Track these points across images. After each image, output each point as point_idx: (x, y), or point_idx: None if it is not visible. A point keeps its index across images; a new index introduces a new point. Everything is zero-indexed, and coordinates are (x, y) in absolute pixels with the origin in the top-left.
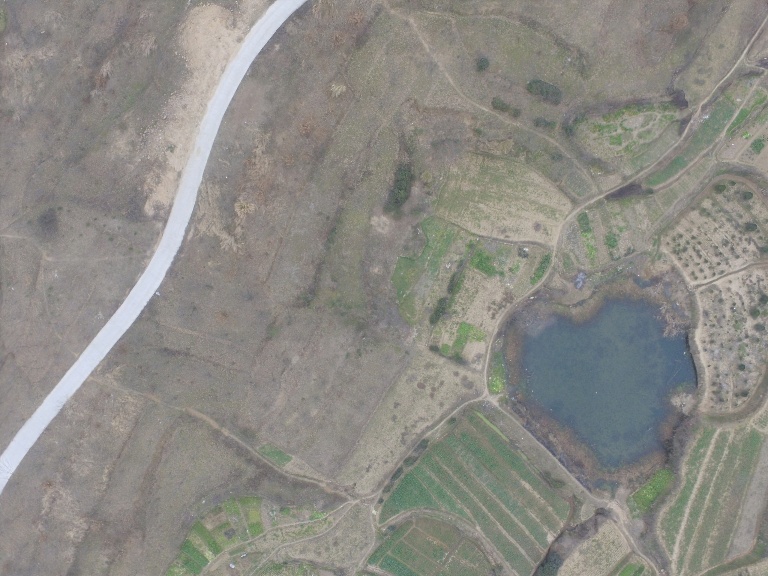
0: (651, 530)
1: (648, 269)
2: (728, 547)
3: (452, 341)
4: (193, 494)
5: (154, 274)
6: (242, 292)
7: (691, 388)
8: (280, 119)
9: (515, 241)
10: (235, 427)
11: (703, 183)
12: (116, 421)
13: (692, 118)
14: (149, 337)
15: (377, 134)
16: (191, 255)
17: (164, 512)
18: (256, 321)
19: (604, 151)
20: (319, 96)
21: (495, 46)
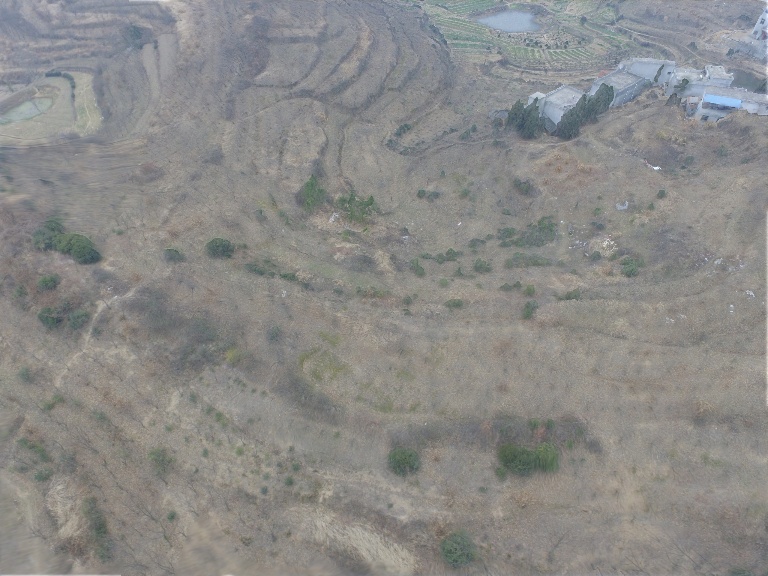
0: None
1: None
2: None
3: None
4: None
5: None
6: None
7: None
8: None
9: None
10: None
11: None
12: None
13: None
14: None
15: None
16: None
17: None
18: None
19: None
20: None
21: None
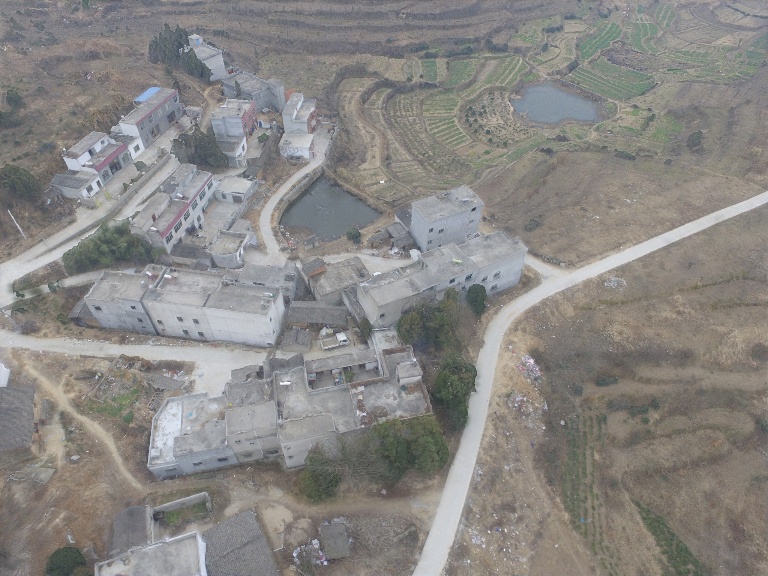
0: None
1: None
2: None
3: None
4: None
5: None
6: None
7: None
8: None
9: None
10: None
11: None
12: None
13: None
14: None
15: None
16: None
17: None
18: None
19: None
20: (766, 153)
21: None
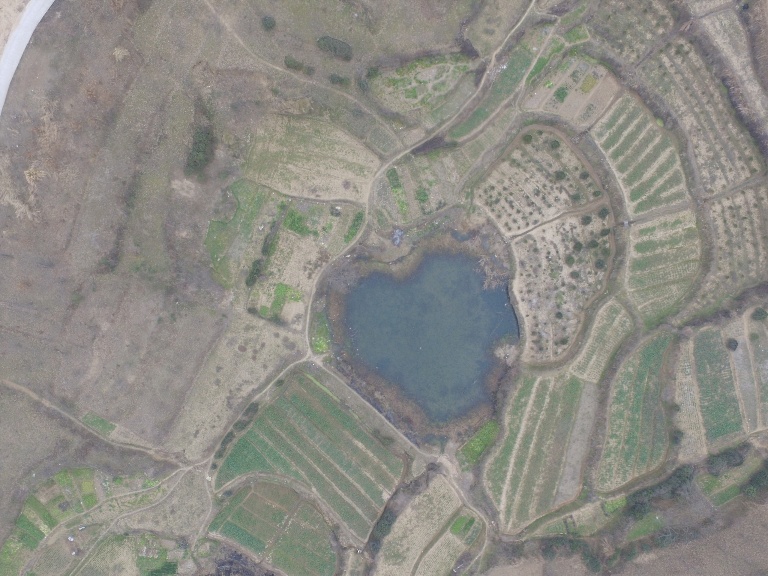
0: (478, 482)
1: (464, 223)
2: (554, 495)
3: (270, 303)
4: (20, 467)
5: None
6: (43, 260)
7: (514, 339)
8: (67, 86)
9: (327, 200)
10: (55, 397)
11: (511, 134)
12: None
13: (488, 68)
14: None
15: (171, 98)
16: None
17: None
18: (60, 289)
19: (401, 105)
20: (105, 61)
21: (279, 4)
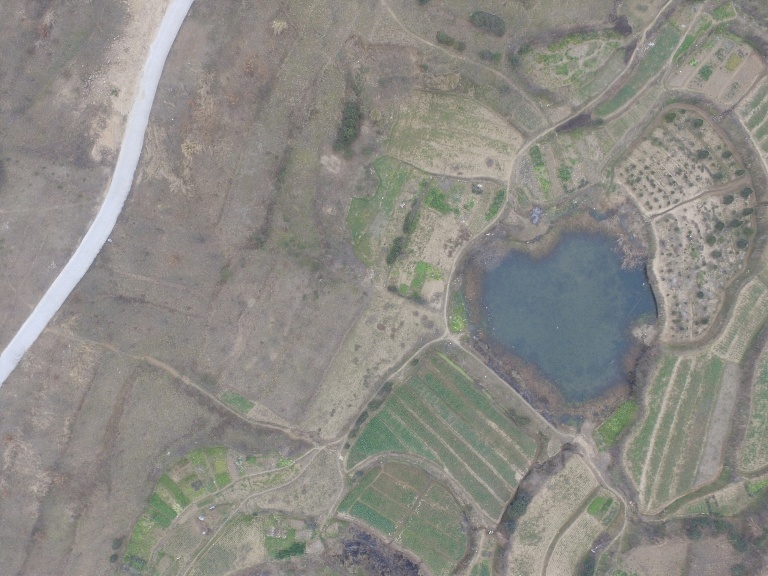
0: (617, 462)
1: (603, 202)
2: (695, 475)
3: (410, 281)
4: (157, 445)
5: (105, 221)
6: (194, 235)
7: (652, 319)
8: (224, 59)
9: (468, 178)
10: (195, 375)
11: (653, 112)
12: (74, 372)
13: (637, 45)
14: (103, 285)
15: (323, 72)
16: (141, 199)
17: (129, 465)
18: (210, 264)
19: (551, 81)
20: (262, 35)
21: None
